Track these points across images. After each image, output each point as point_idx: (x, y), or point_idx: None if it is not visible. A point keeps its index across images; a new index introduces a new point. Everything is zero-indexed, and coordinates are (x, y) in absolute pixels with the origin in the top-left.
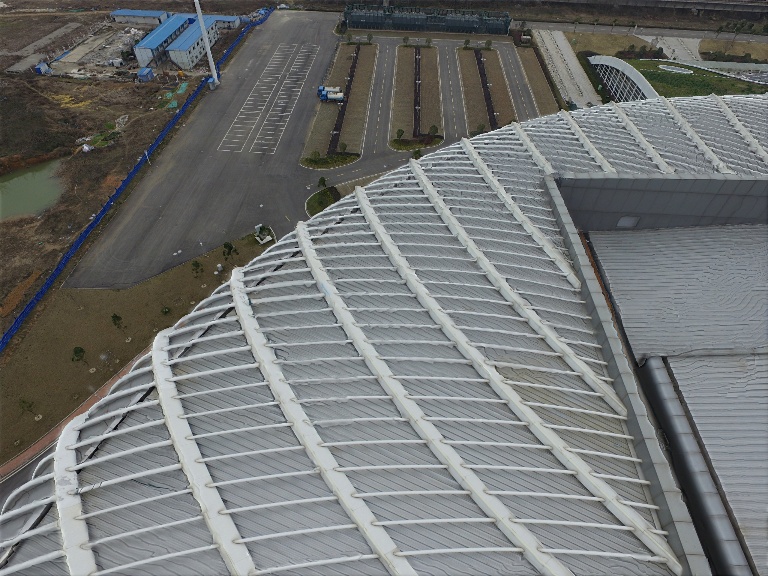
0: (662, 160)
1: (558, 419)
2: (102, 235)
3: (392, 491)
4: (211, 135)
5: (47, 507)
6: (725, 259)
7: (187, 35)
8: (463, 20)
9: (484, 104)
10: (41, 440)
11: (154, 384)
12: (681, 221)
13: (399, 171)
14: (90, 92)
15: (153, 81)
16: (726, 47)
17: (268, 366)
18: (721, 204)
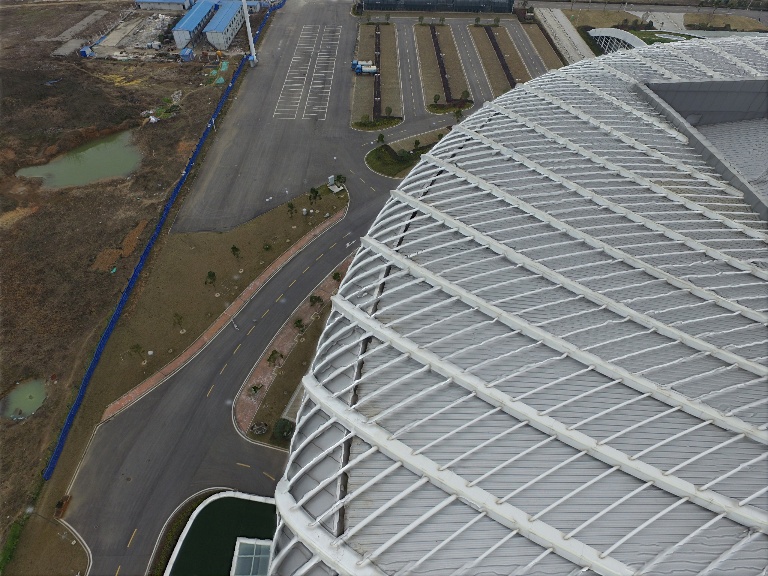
0: (715, 72)
1: (702, 200)
2: (191, 190)
3: (616, 234)
4: (263, 106)
5: (388, 268)
6: (766, 141)
7: (219, 18)
8: None
9: (503, 73)
10: (190, 348)
11: (418, 209)
12: (731, 117)
13: (514, 91)
14: (138, 72)
15: (195, 61)
16: (708, 19)
17: (499, 190)
18: (761, 101)
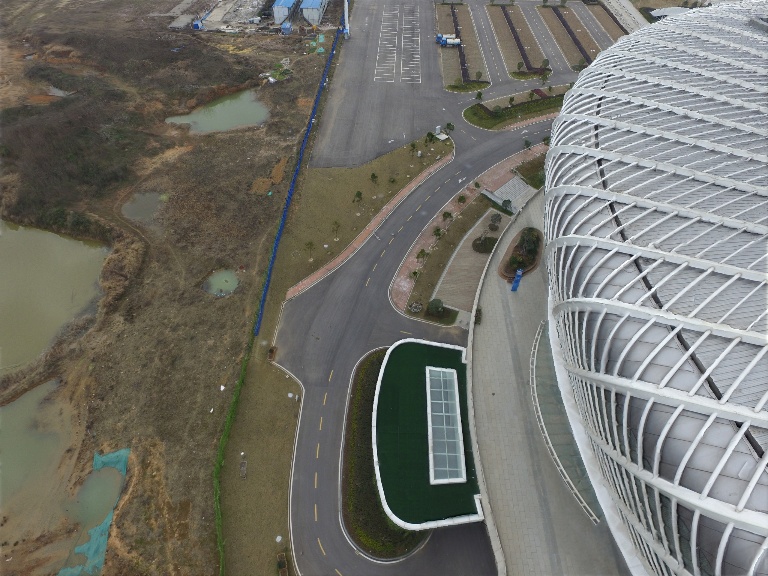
0: None
1: None
2: (318, 136)
3: (766, 102)
4: (364, 71)
5: (595, 127)
6: None
7: None
8: None
9: (575, 47)
10: (344, 252)
11: (603, 95)
12: None
13: (643, 29)
14: (247, 42)
15: (294, 34)
16: None
17: None
18: None
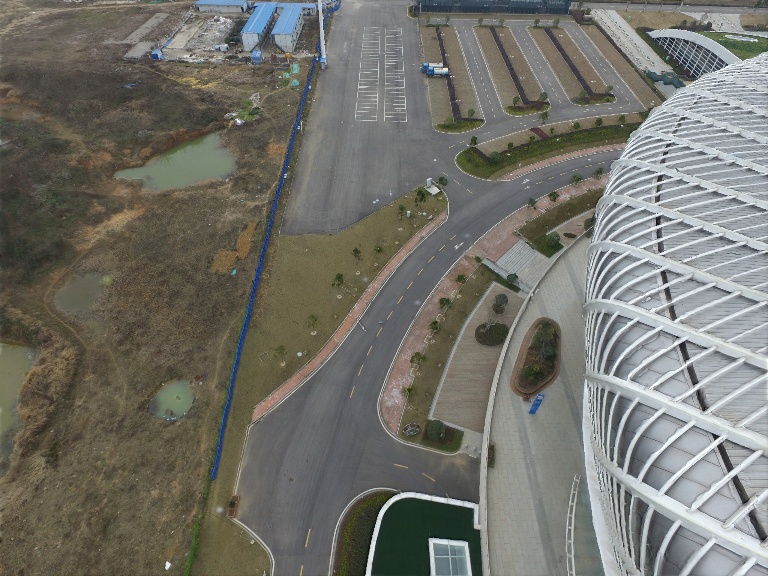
0: None
1: None
2: (291, 193)
3: None
4: (343, 108)
5: (662, 273)
6: None
7: (285, 20)
8: (527, 2)
9: (573, 75)
10: (323, 350)
11: (662, 214)
12: None
13: (684, 95)
14: (212, 74)
15: (265, 63)
16: (767, 20)
17: None
18: None
